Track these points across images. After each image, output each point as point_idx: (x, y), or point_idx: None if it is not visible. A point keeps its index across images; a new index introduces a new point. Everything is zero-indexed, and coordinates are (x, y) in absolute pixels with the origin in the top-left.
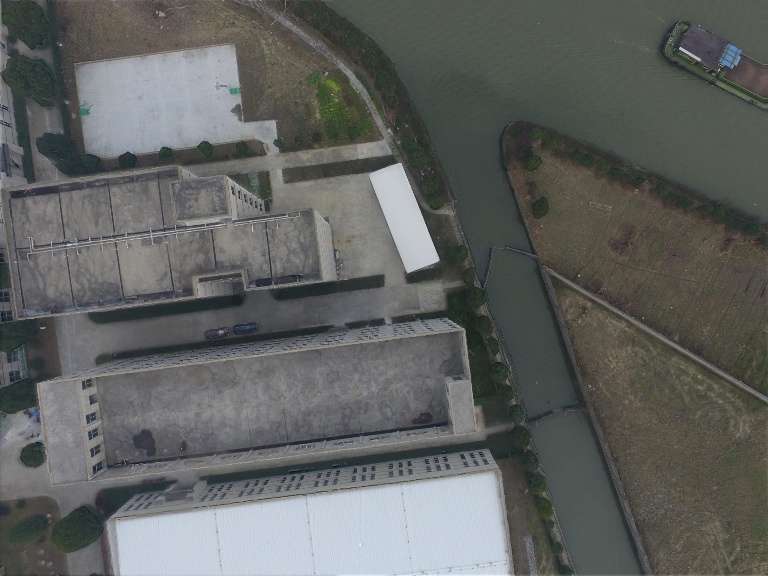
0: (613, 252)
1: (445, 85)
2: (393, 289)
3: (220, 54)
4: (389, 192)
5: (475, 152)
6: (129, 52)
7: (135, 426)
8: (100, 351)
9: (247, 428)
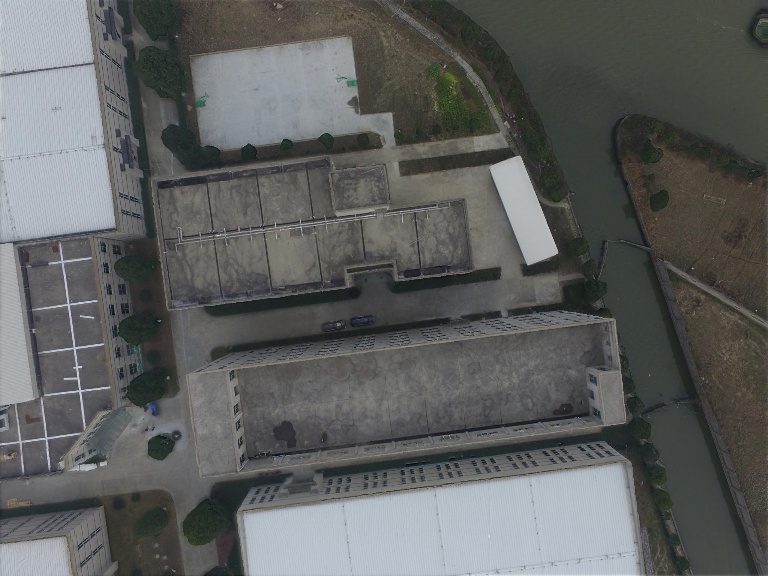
0: (726, 245)
1: (559, 78)
2: (509, 282)
3: (336, 46)
4: (509, 185)
5: (587, 145)
6: (245, 44)
7: (276, 418)
8: (215, 344)
9: (388, 419)
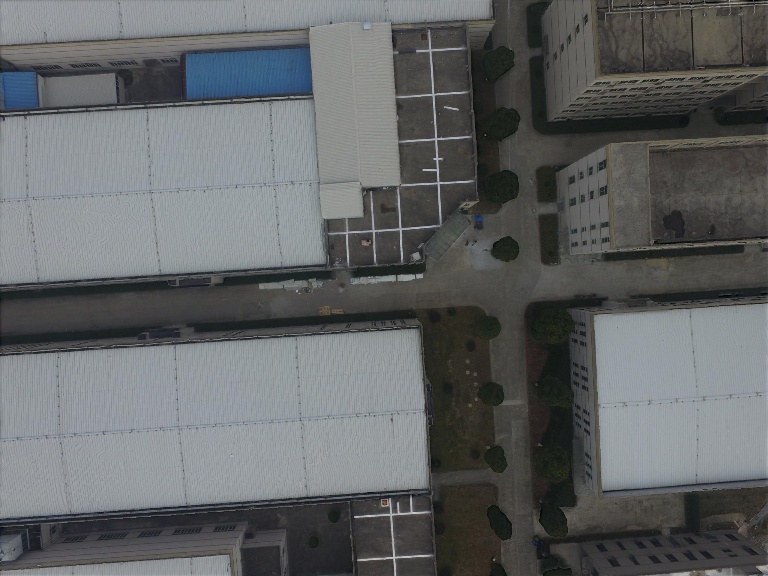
0: None
1: None
2: None
3: None
4: None
5: None
6: None
7: (667, 206)
8: (541, 163)
9: None
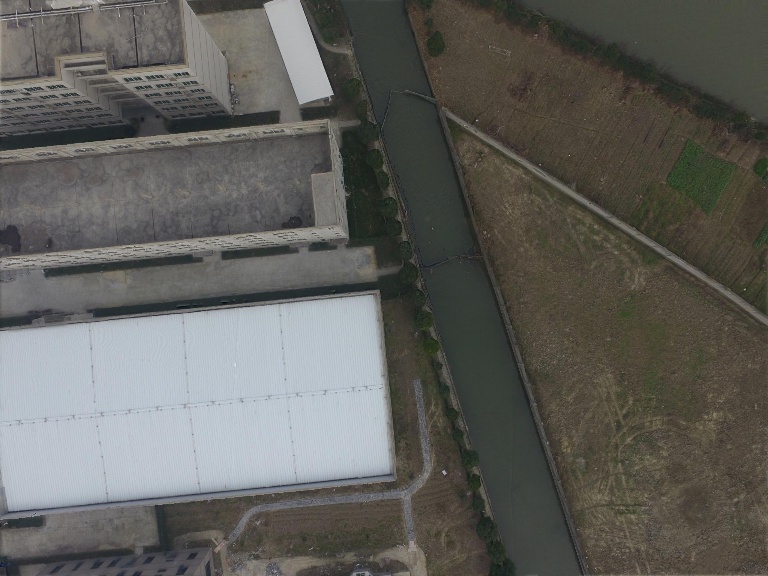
0: (512, 98)
1: None
2: None
3: None
4: (284, 23)
5: None
6: None
7: (1, 221)
8: None
9: (114, 227)
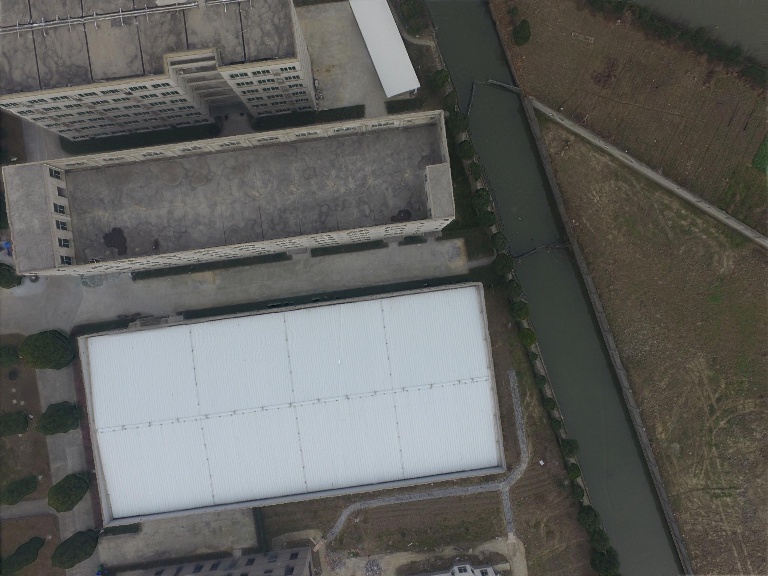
0: (596, 85)
1: None
2: None
3: None
4: (369, 15)
5: None
6: None
7: (106, 224)
8: None
9: (221, 226)
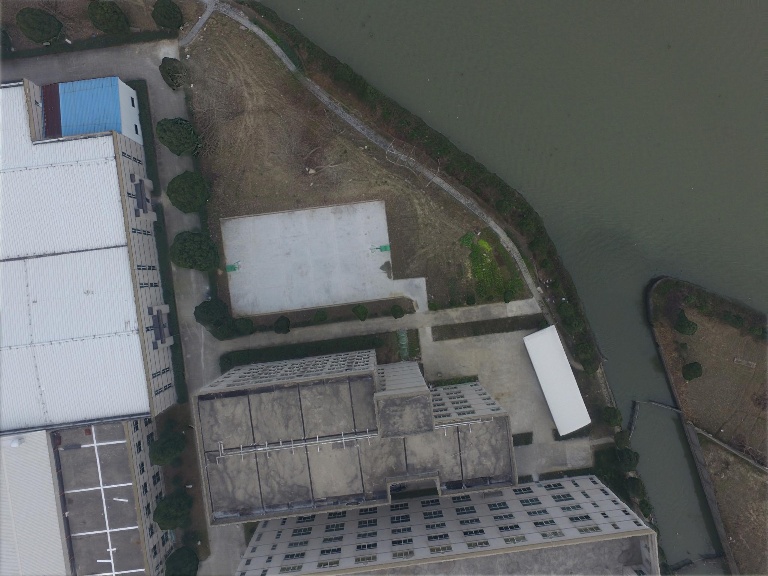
0: (755, 407)
1: (592, 240)
2: (541, 446)
3: (369, 210)
4: (543, 355)
5: (618, 304)
6: (277, 207)
7: None
8: None
9: None
